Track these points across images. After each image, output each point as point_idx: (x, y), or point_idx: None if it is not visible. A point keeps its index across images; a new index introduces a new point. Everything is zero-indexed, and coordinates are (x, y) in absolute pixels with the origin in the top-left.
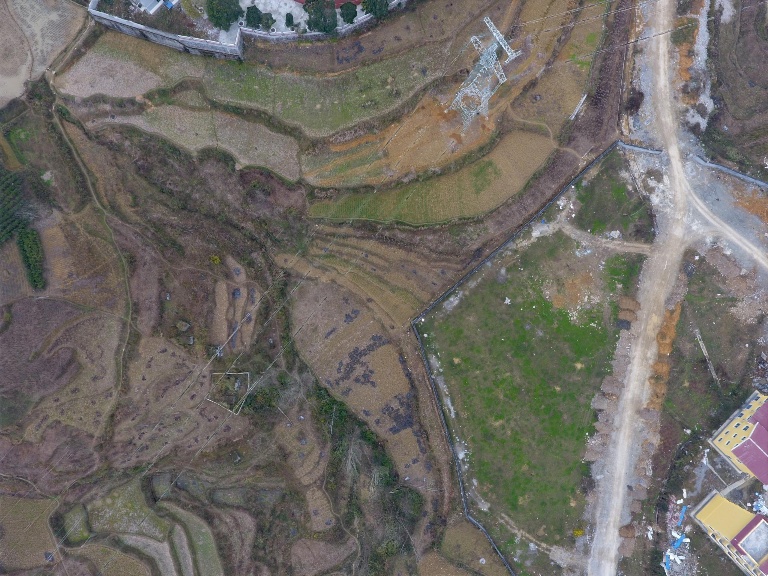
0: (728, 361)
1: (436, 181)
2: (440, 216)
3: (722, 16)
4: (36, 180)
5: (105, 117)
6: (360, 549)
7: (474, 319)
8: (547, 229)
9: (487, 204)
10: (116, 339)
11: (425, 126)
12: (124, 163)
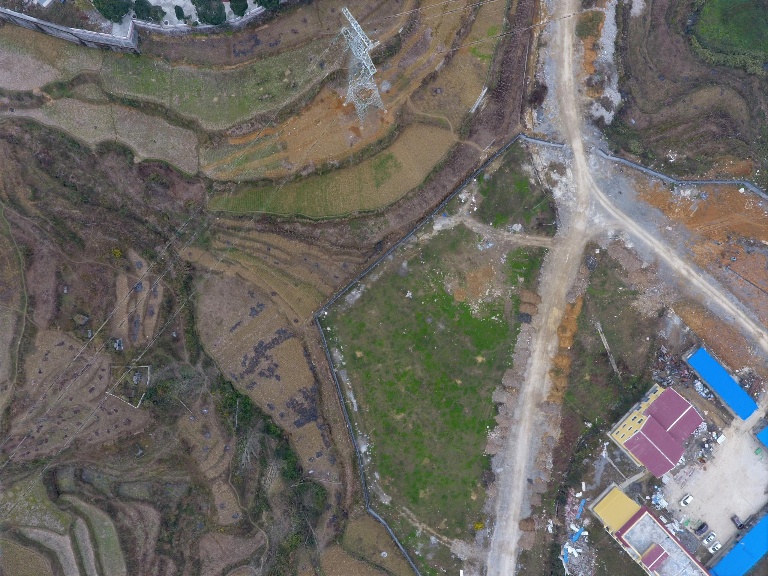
0: (629, 354)
1: (336, 174)
2: (340, 209)
3: (632, 9)
4: None
5: (4, 110)
6: (268, 543)
7: (376, 312)
8: (449, 222)
9: (387, 197)
10: (11, 332)
11: (324, 119)
12: (24, 156)
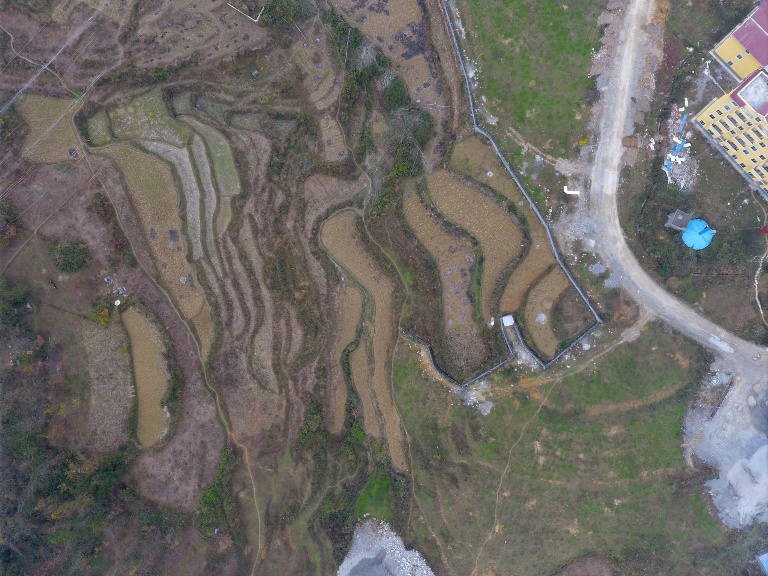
0: None
1: None
2: None
3: None
4: None
5: None
6: (371, 185)
7: None
8: None
9: None
10: None
11: None
12: None
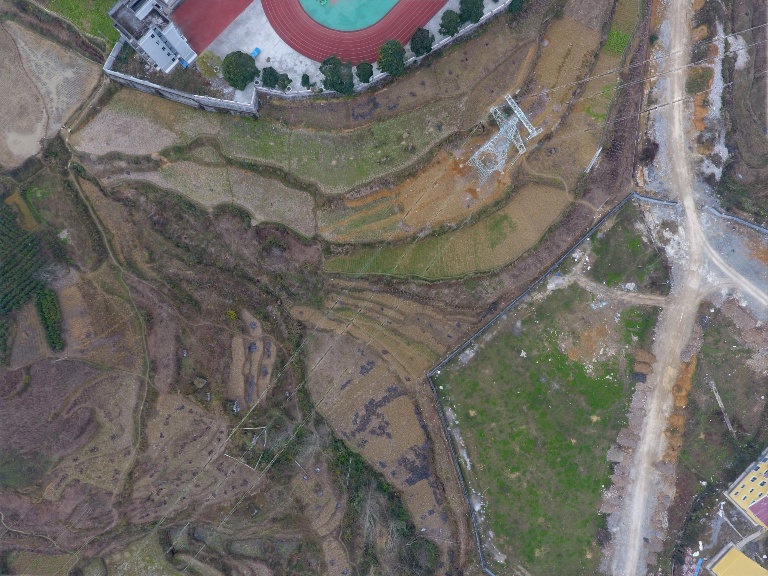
0: (744, 413)
1: (451, 235)
2: (456, 270)
3: (736, 63)
4: (53, 239)
5: (120, 173)
6: None
7: (490, 372)
8: (562, 282)
9: (503, 258)
10: (134, 398)
11: (440, 181)
12: (140, 219)
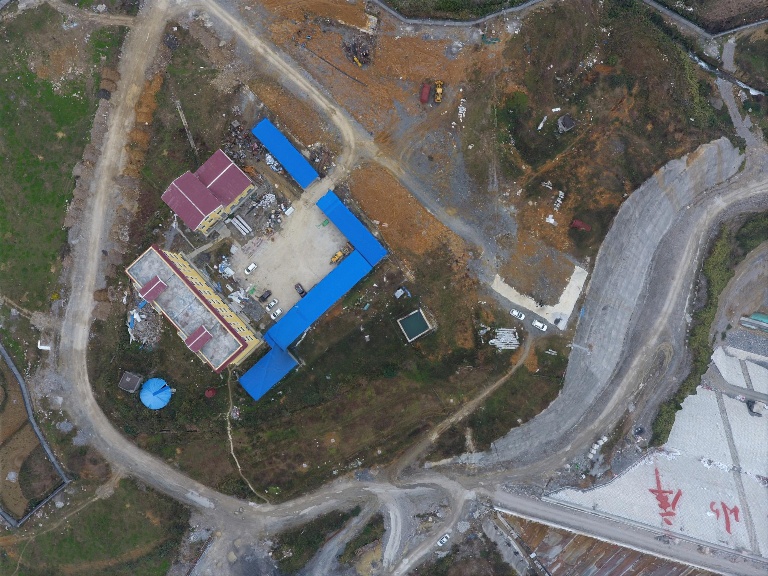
0: (207, 131)
1: None
2: None
3: None
4: None
5: None
6: None
7: None
8: (33, 2)
9: None
10: None
11: None
12: None
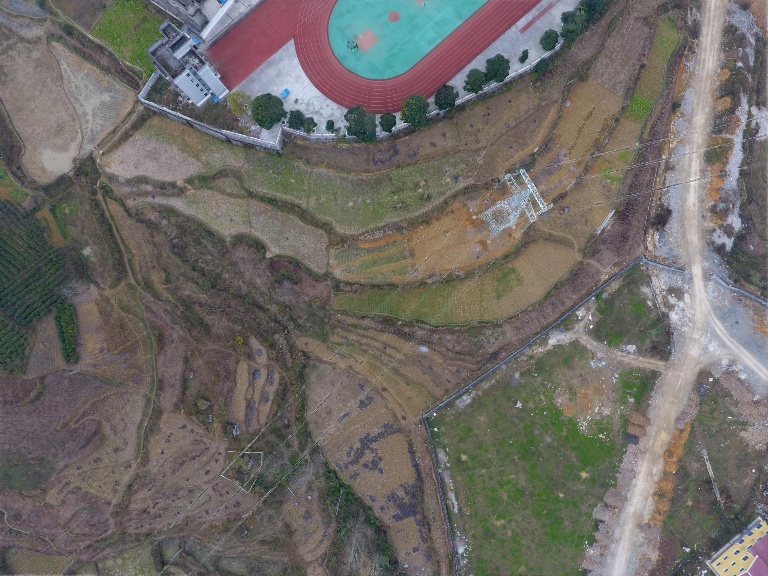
0: (733, 484)
1: (459, 283)
2: (460, 318)
3: (758, 134)
4: (77, 255)
5: (146, 196)
6: None
7: (485, 419)
8: (564, 338)
9: (507, 310)
10: (140, 414)
11: (453, 230)
12: (160, 241)
